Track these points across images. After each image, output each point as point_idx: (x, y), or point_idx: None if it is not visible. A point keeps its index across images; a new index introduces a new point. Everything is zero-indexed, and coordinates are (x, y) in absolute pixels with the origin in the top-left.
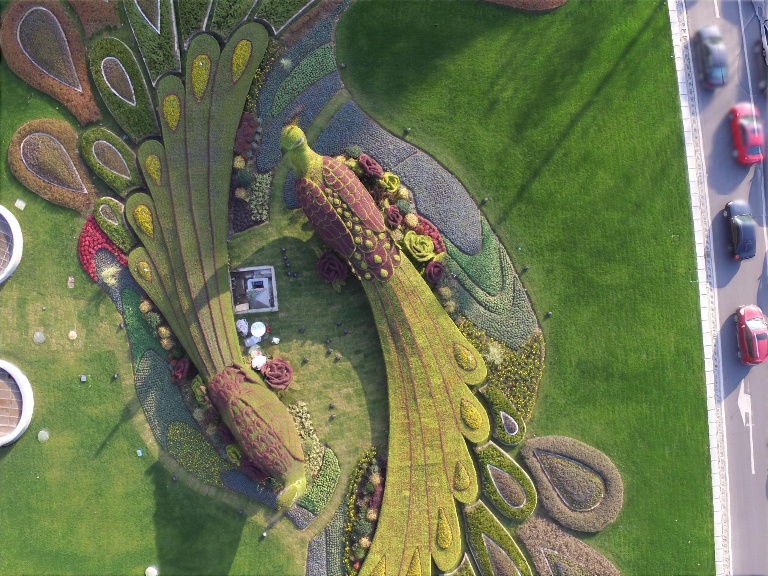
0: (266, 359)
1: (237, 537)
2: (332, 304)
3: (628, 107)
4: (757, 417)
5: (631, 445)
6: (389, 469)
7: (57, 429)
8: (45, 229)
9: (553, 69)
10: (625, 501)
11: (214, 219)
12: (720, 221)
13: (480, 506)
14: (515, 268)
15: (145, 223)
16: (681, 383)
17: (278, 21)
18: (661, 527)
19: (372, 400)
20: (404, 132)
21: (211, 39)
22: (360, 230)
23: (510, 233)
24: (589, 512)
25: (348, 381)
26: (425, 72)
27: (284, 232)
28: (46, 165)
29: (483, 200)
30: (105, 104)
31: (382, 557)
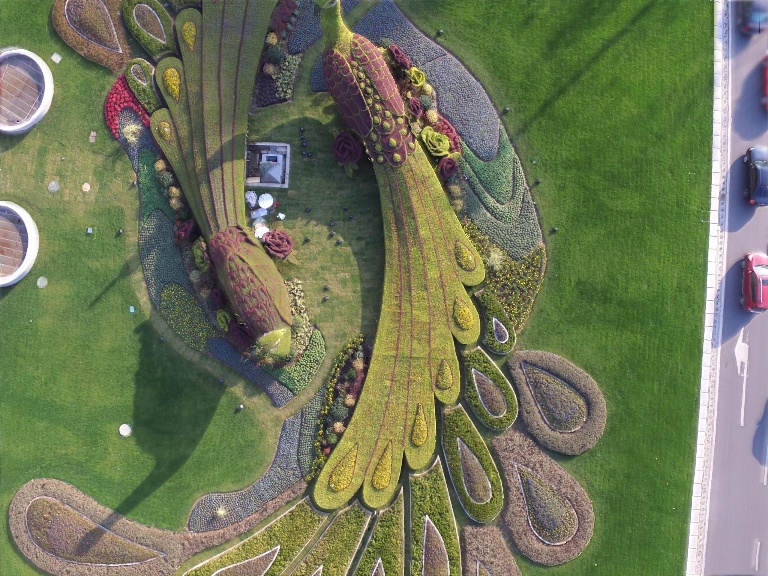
0: (269, 230)
1: (214, 405)
2: (341, 188)
3: (661, 41)
4: (753, 369)
5: (620, 374)
6: (374, 356)
7: (57, 277)
8: (76, 83)
9: None
10: (607, 430)
11: (239, 88)
12: (739, 166)
13: (460, 410)
14: (527, 180)
15: (172, 85)
16: (679, 320)
17: None
18: (640, 463)
19: (367, 288)
20: (436, 34)
21: None
22: (379, 109)
23: (527, 145)
24: (569, 434)
25: (346, 266)
26: None
27: (305, 112)
28: (87, 22)
29: (504, 109)
30: None
31: (354, 445)
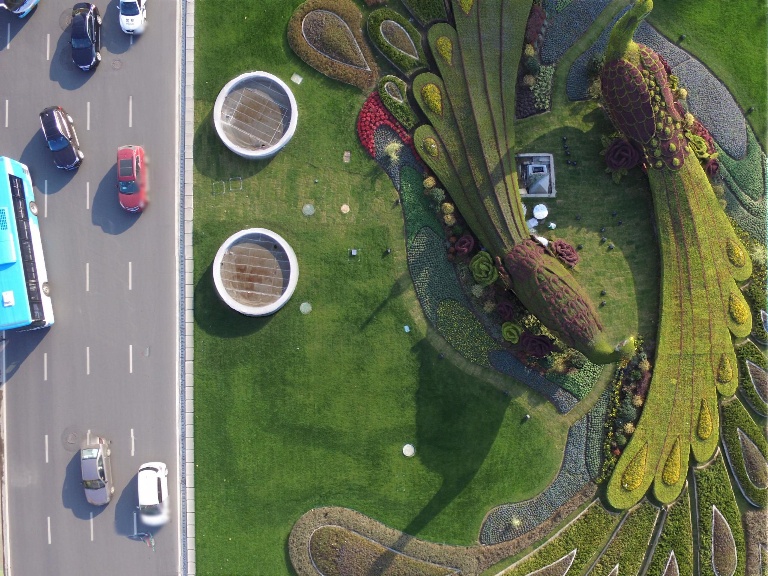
0: None
1: (500, 418)
2: (608, 194)
3: None
4: None
5: None
6: (659, 356)
7: (321, 302)
8: (322, 103)
9: None
10: None
11: (505, 101)
12: None
13: (737, 401)
14: None
15: (435, 101)
16: None
17: None
18: None
19: (641, 290)
20: (679, 39)
21: None
22: (663, 116)
23: None
24: None
25: (619, 270)
26: None
27: (565, 122)
28: (330, 40)
29: (750, 109)
30: None
31: (645, 444)
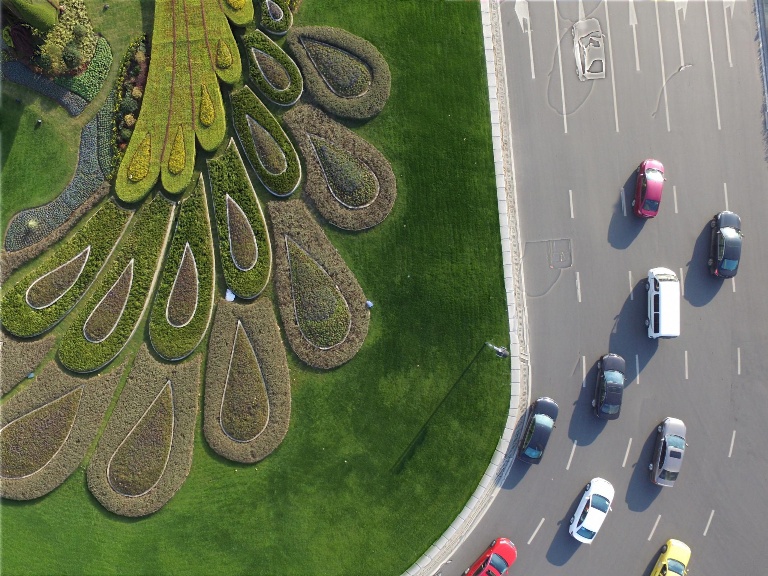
0: None
1: (15, 126)
2: None
3: None
4: (536, 24)
5: (401, 39)
6: (153, 46)
7: None
8: None
9: None
10: (395, 93)
11: None
12: None
13: (245, 88)
14: None
15: None
16: None
17: None
18: (433, 121)
19: None
20: None
21: None
22: None
23: None
24: (355, 98)
25: None
26: None
27: None
28: None
29: None
30: None
31: (146, 134)
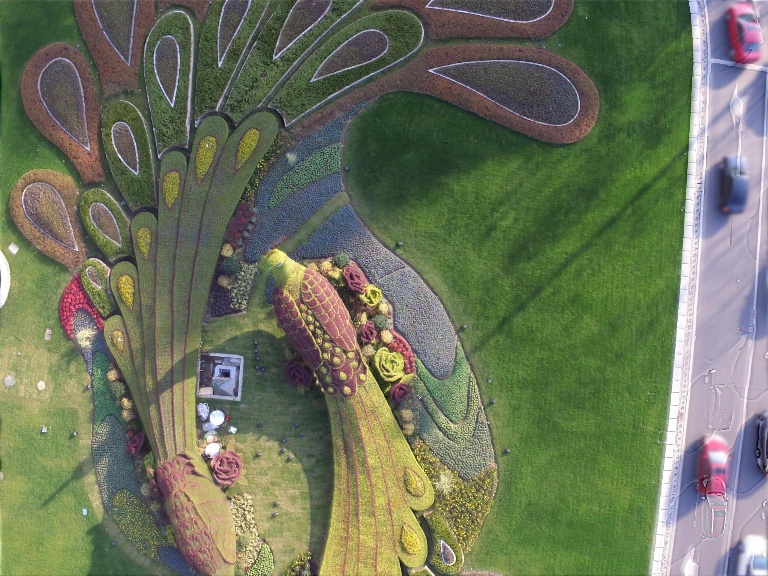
0: (219, 449)
1: None
2: (294, 404)
3: (627, 256)
4: None
5: None
6: None
7: (12, 472)
8: (33, 277)
9: (557, 205)
10: None
11: (193, 303)
12: (700, 386)
13: None
14: (482, 400)
15: (126, 293)
16: (629, 542)
17: (290, 114)
18: None
19: (317, 505)
20: (395, 245)
21: (221, 122)
22: (329, 347)
23: (483, 364)
24: None
25: (296, 483)
26: (427, 188)
27: (259, 325)
28: (43, 216)
29: (462, 327)
30: (109, 167)
31: None
